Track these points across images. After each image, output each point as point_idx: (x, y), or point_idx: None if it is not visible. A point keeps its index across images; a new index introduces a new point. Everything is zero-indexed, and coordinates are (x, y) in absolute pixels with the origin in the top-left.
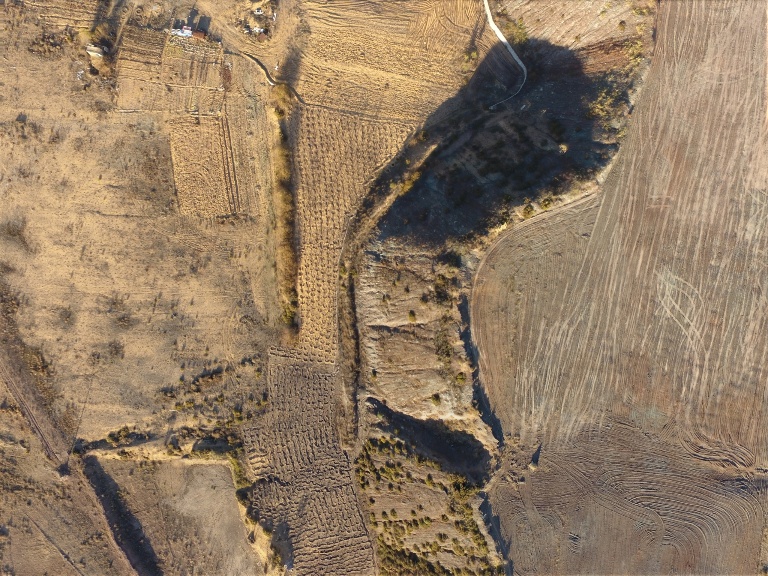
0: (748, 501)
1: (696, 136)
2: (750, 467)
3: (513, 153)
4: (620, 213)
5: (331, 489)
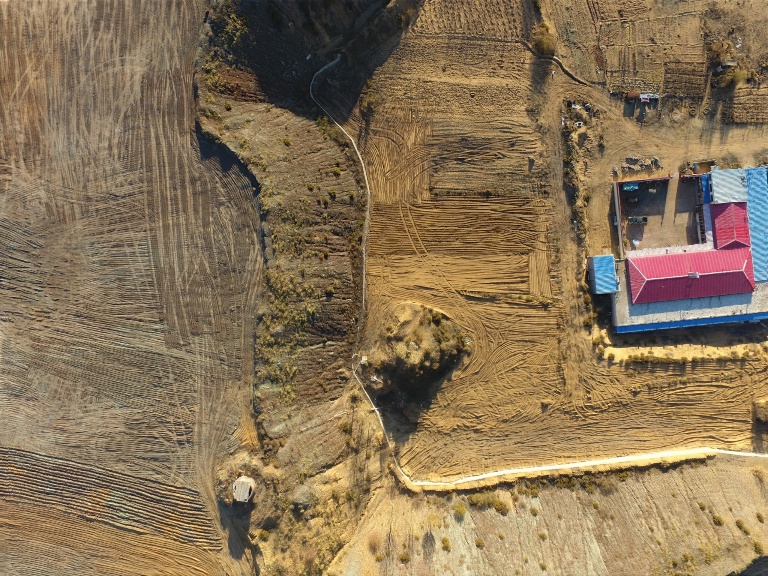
0: None
1: (137, 2)
2: None
3: None
4: None
5: None
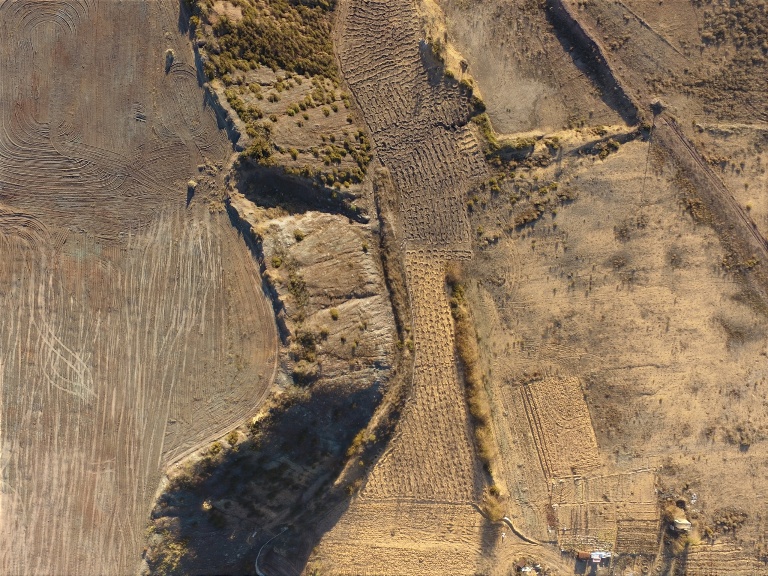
0: None
1: (75, 538)
2: None
3: (257, 491)
4: (141, 450)
5: (392, 126)
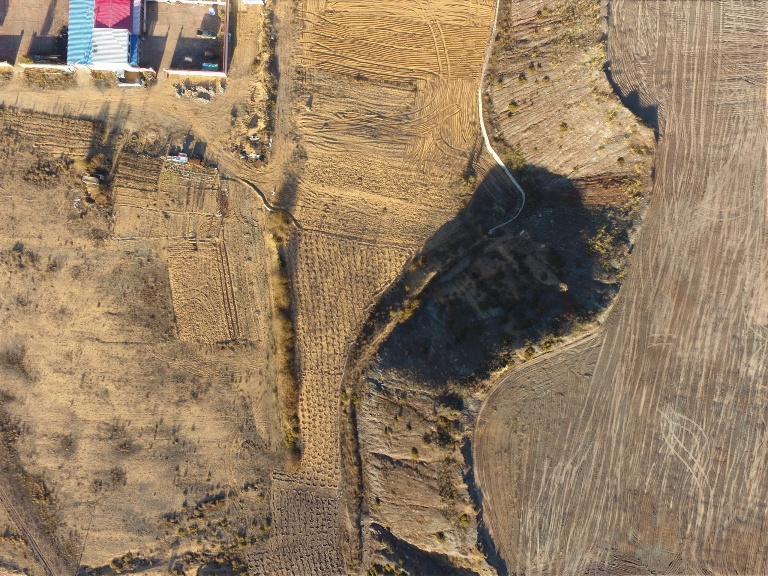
0: None
1: (697, 274)
2: None
3: (513, 287)
4: (622, 352)
5: None
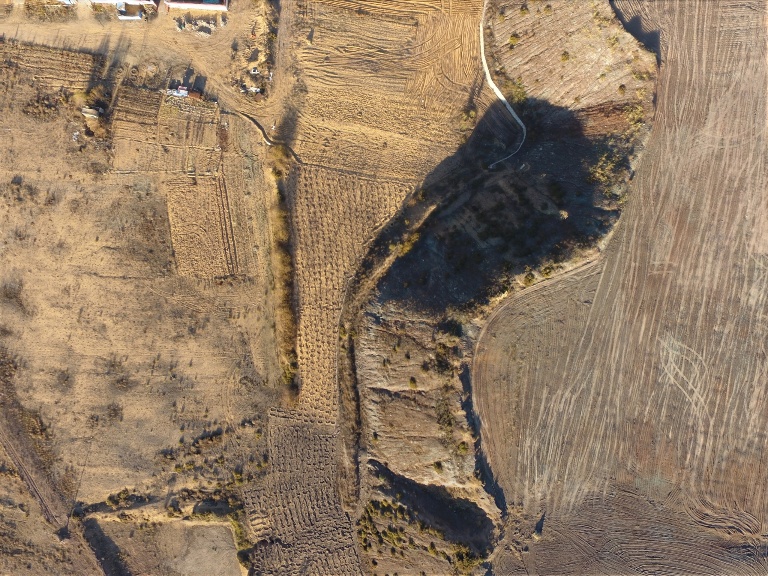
0: (754, 568)
1: (698, 201)
2: (756, 534)
3: (513, 217)
4: (622, 280)
5: (333, 551)
